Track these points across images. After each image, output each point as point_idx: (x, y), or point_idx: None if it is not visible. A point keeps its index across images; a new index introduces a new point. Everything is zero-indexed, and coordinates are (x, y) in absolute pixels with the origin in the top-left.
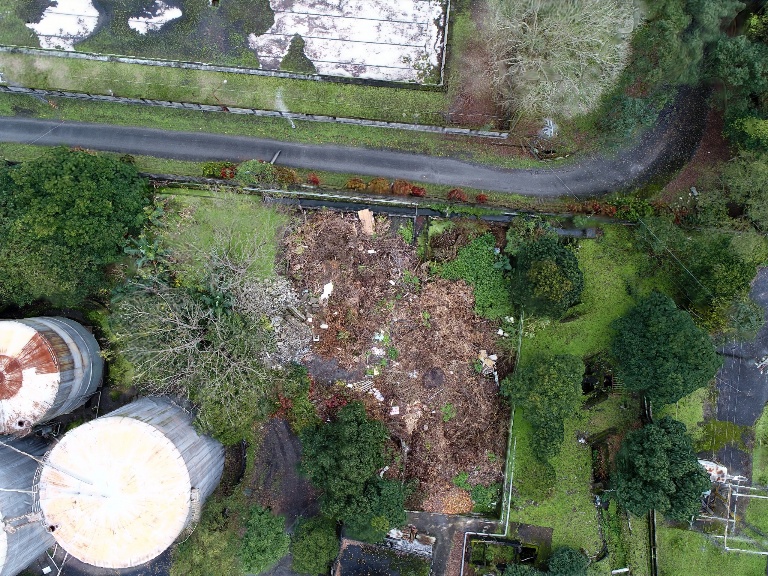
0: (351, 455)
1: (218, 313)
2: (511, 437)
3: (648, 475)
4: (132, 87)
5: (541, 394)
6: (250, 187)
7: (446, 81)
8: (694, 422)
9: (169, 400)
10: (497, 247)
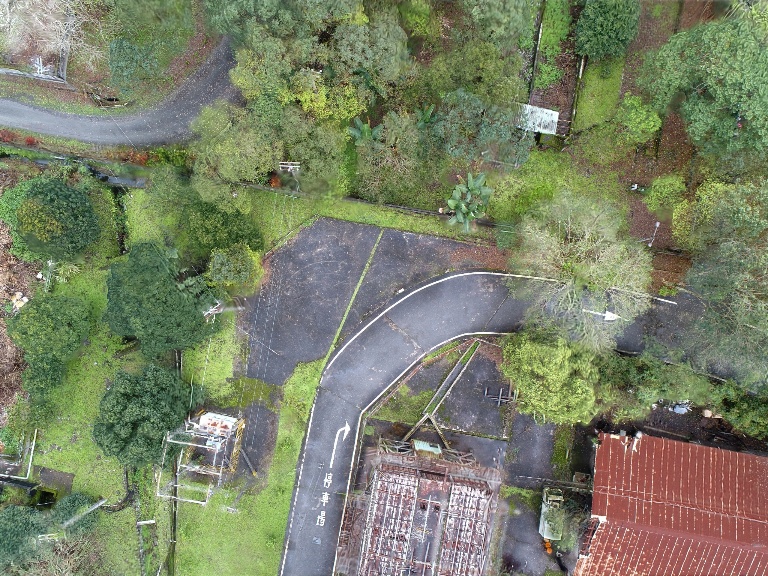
0: None
1: None
2: None
3: None
4: None
5: (24, 333)
6: None
7: None
8: (223, 378)
9: None
10: None
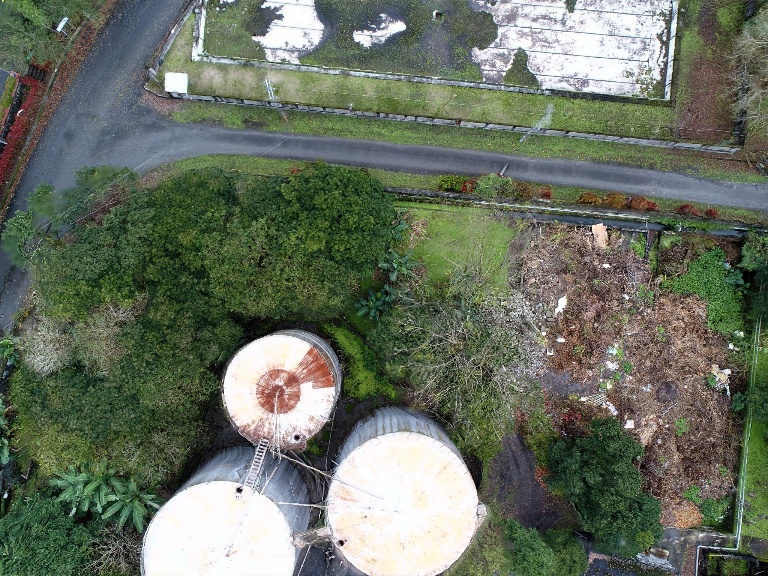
0: (623, 470)
1: (469, 327)
2: (747, 451)
3: None
4: (363, 100)
5: None
6: (481, 201)
7: (674, 96)
8: None
9: (432, 414)
10: (726, 262)
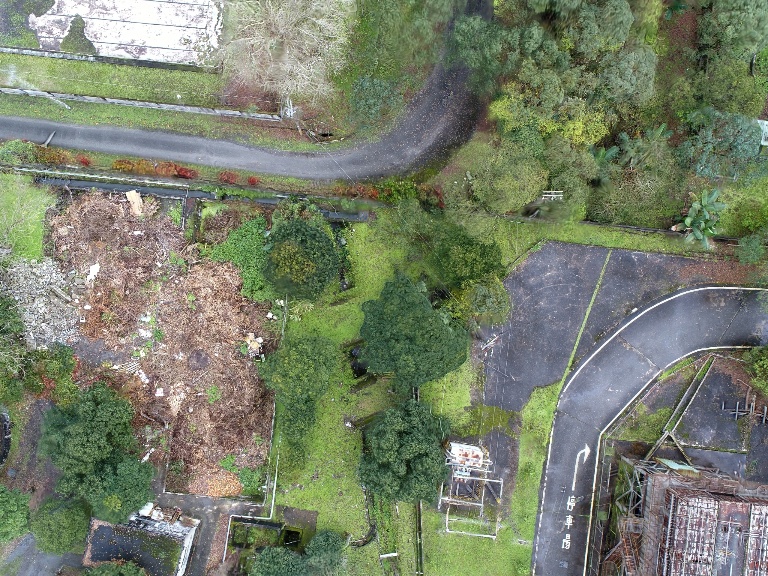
0: (77, 434)
1: None
2: (273, 420)
3: (379, 457)
4: None
5: (284, 376)
6: (21, 167)
7: (221, 63)
8: (461, 407)
9: None
10: (268, 230)
